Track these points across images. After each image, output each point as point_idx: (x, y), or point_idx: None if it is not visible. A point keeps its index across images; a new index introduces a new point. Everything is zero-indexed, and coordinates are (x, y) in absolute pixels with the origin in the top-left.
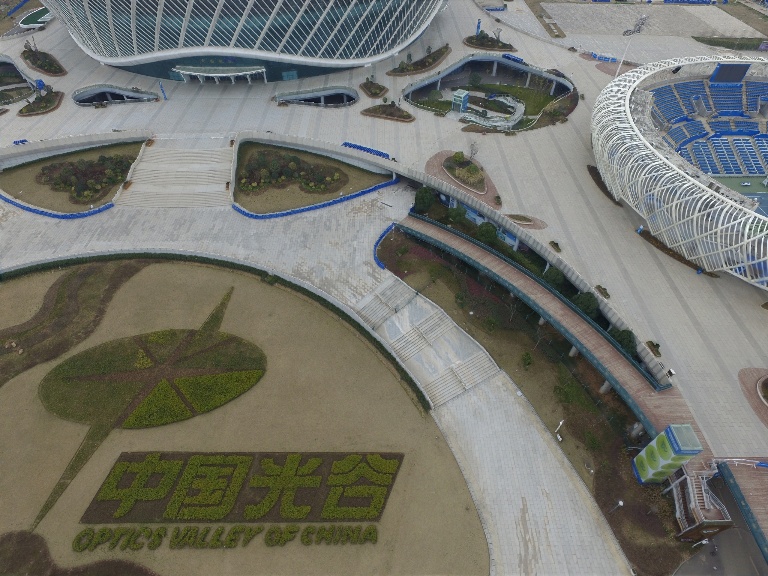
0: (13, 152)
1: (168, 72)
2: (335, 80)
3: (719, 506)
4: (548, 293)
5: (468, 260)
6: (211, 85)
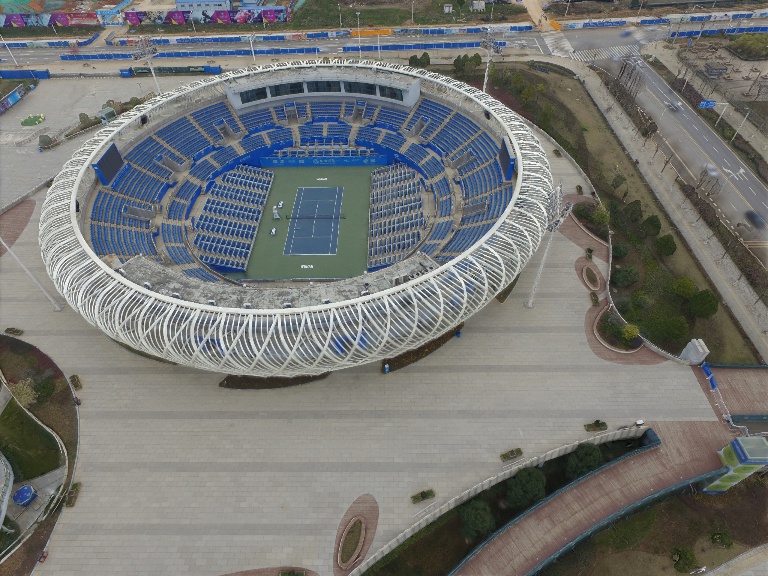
0: None
1: None
2: None
3: None
4: (508, 532)
5: None
6: None
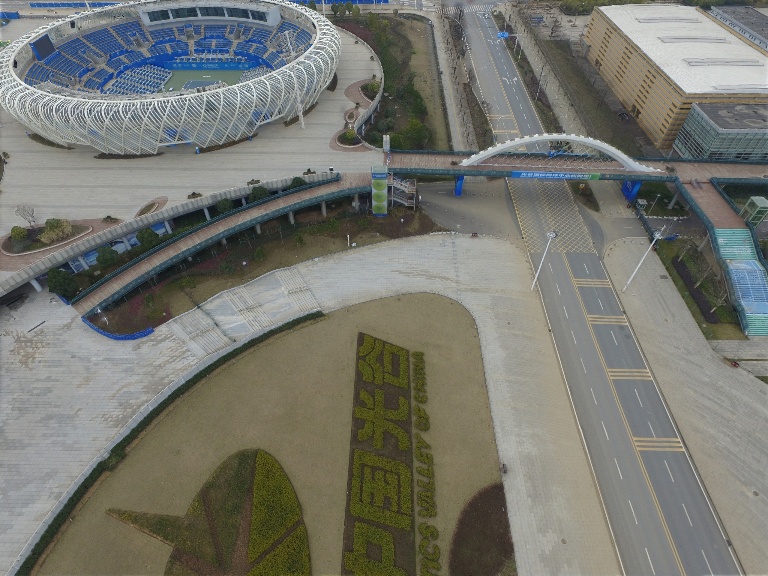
0: None
1: None
2: None
3: (407, 182)
4: (240, 214)
5: (177, 258)
6: None
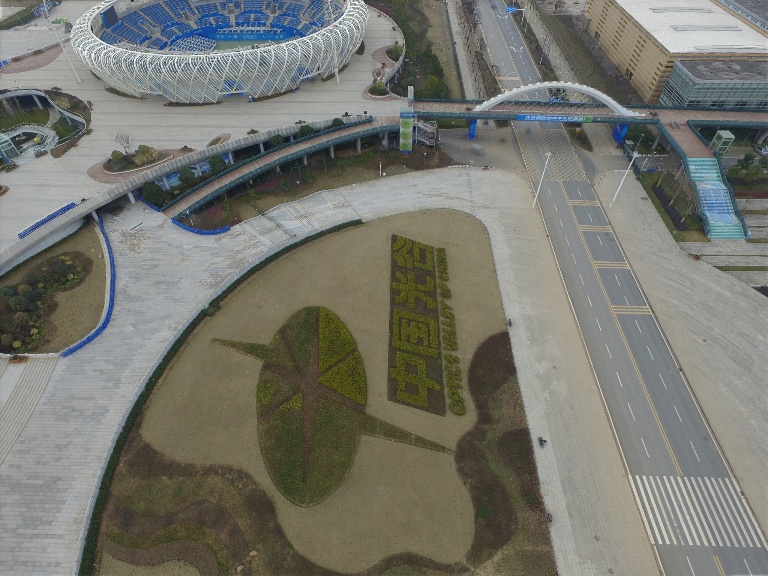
0: None
1: None
2: None
3: None
4: (291, 147)
5: (243, 179)
6: None
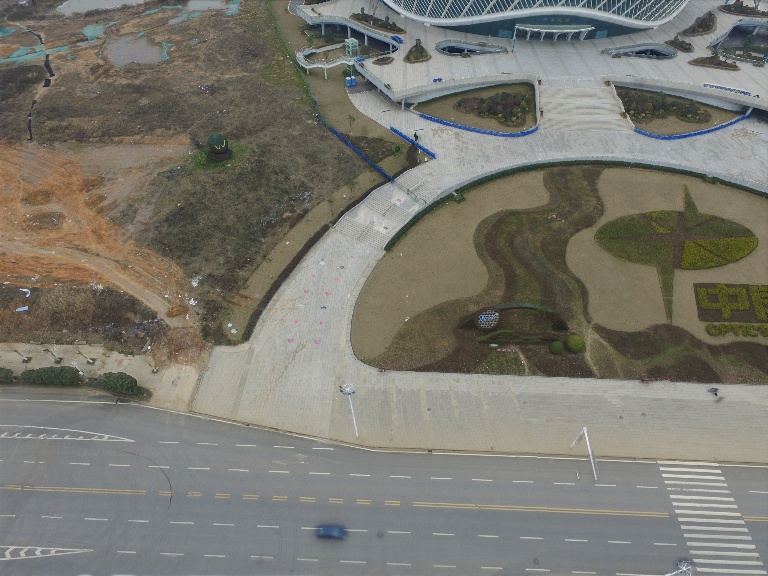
0: (433, 88)
1: (500, 30)
2: (639, 39)
3: None
4: None
5: None
6: (538, 42)
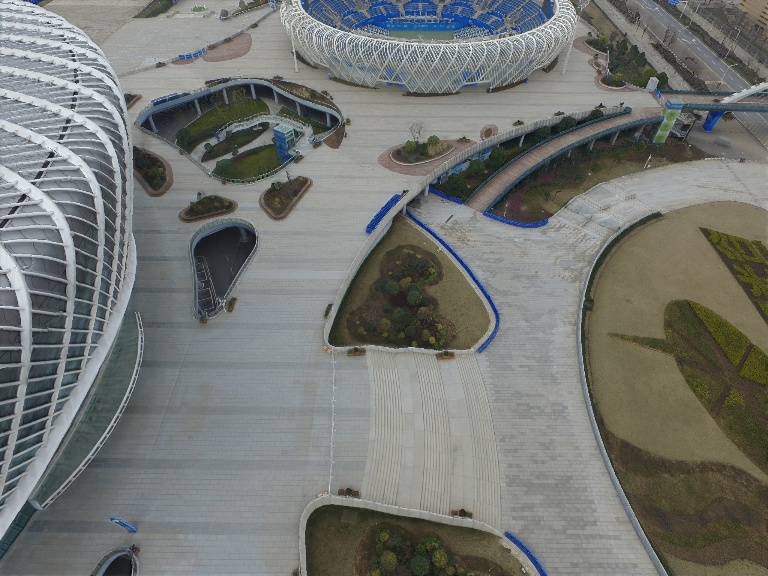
0: None
1: None
2: (154, 248)
3: None
4: (559, 139)
5: (531, 171)
6: None
